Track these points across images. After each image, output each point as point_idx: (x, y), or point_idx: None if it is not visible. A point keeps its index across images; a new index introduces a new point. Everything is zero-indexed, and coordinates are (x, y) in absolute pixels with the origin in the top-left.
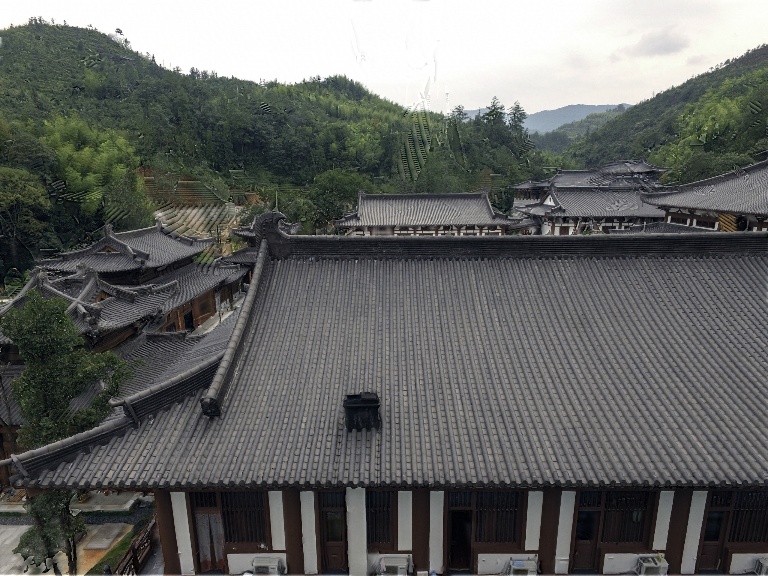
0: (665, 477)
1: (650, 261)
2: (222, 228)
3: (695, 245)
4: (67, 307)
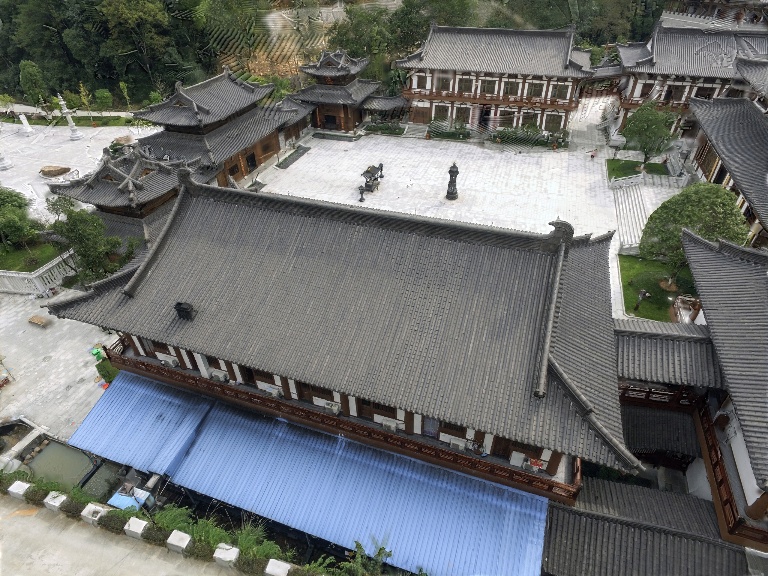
0: (291, 375)
1: (417, 237)
2: (299, 59)
3: (450, 232)
4: (84, 217)
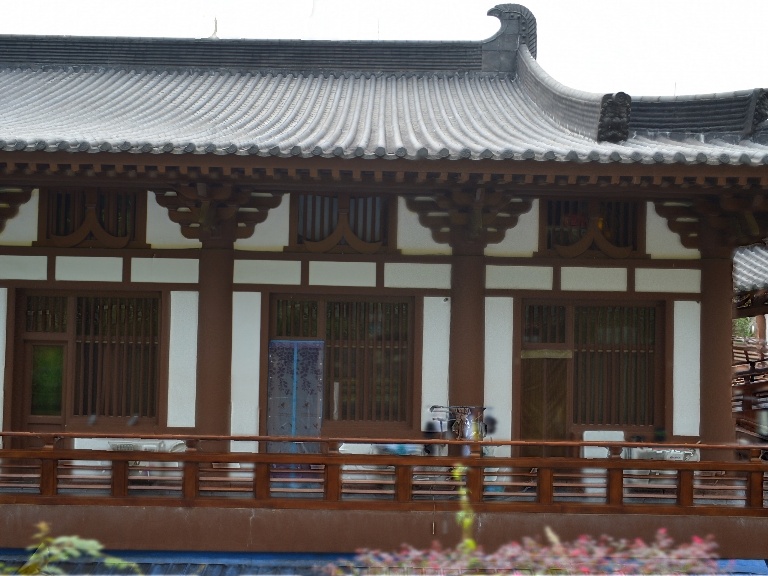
0: None
1: (220, 77)
2: None
3: (294, 56)
4: None
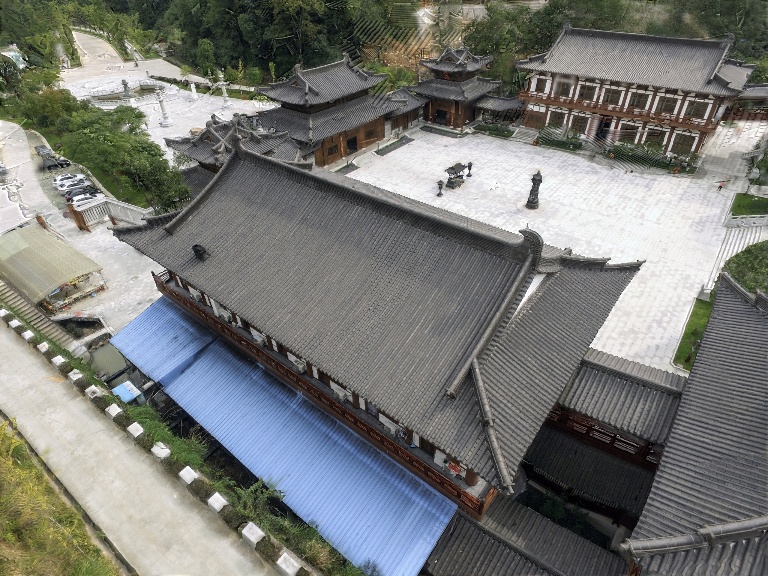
0: (254, 323)
1: (403, 225)
2: (426, 53)
3: (431, 224)
4: (162, 165)
